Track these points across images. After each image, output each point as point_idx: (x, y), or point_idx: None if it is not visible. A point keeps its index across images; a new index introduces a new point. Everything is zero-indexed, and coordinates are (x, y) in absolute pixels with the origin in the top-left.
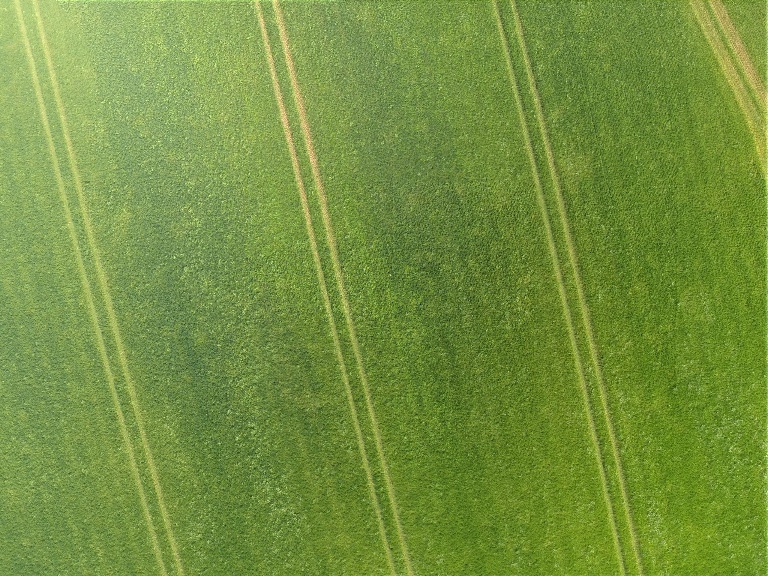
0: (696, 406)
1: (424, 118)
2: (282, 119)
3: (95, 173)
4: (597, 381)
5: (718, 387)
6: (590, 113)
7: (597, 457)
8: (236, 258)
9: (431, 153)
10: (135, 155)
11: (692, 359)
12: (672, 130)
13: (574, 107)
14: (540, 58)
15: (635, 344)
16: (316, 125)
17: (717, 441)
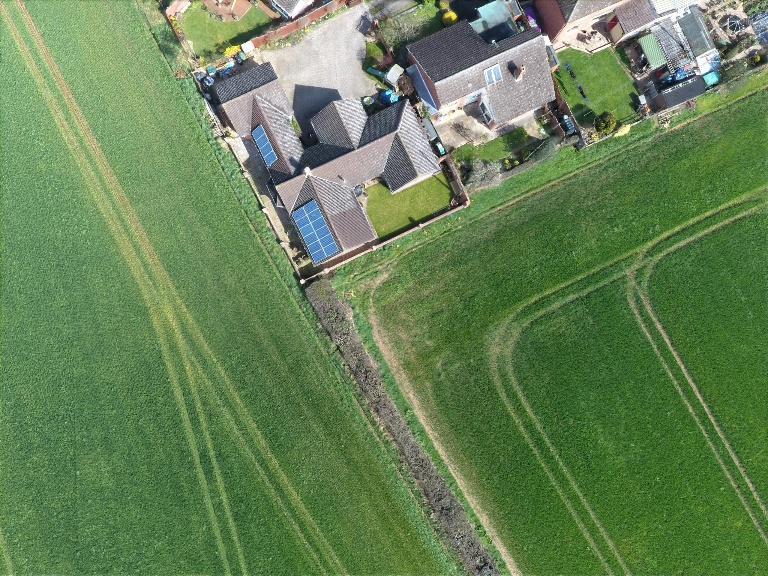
0: (101, 569)
1: None
2: None
3: None
4: (0, 550)
5: (121, 550)
6: None
7: None
8: None
9: None
10: None
11: (94, 525)
12: (67, 306)
13: None
14: None
15: (36, 513)
16: None
17: None
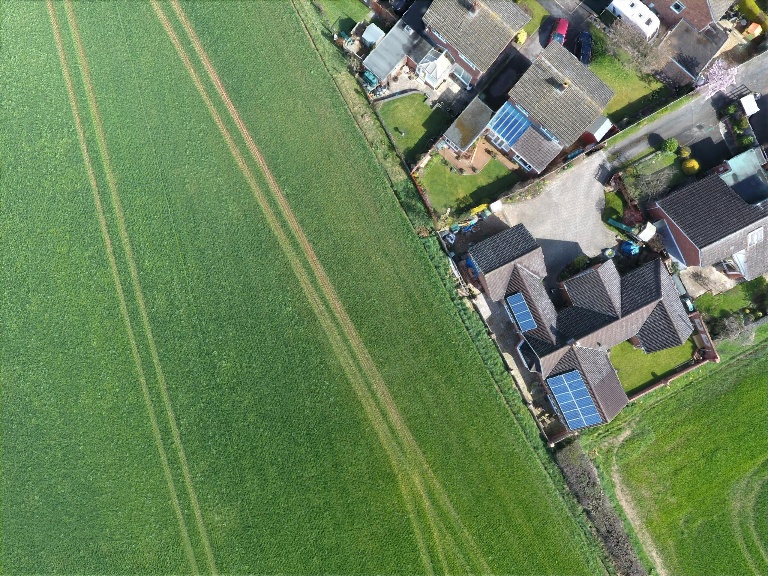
0: None
1: (65, 478)
2: None
3: None
4: None
5: None
6: (235, 464)
7: None
8: None
9: (74, 513)
10: None
11: None
12: (318, 475)
13: (219, 459)
14: (183, 412)
15: None
16: None
17: None
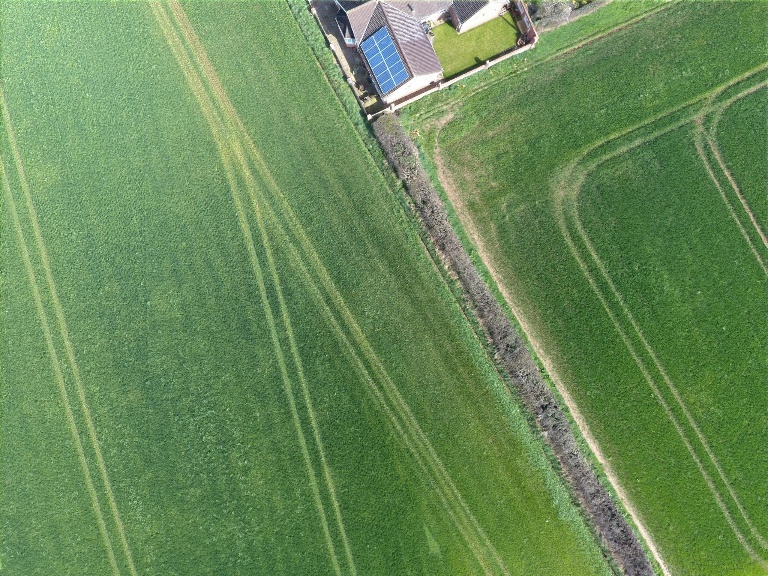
0: (170, 399)
1: None
2: None
3: None
4: (73, 377)
5: (190, 380)
6: (56, 123)
7: (78, 449)
8: None
9: None
10: None
11: (163, 355)
12: (138, 139)
13: (41, 117)
14: (6, 71)
15: (108, 341)
16: None
17: (192, 431)
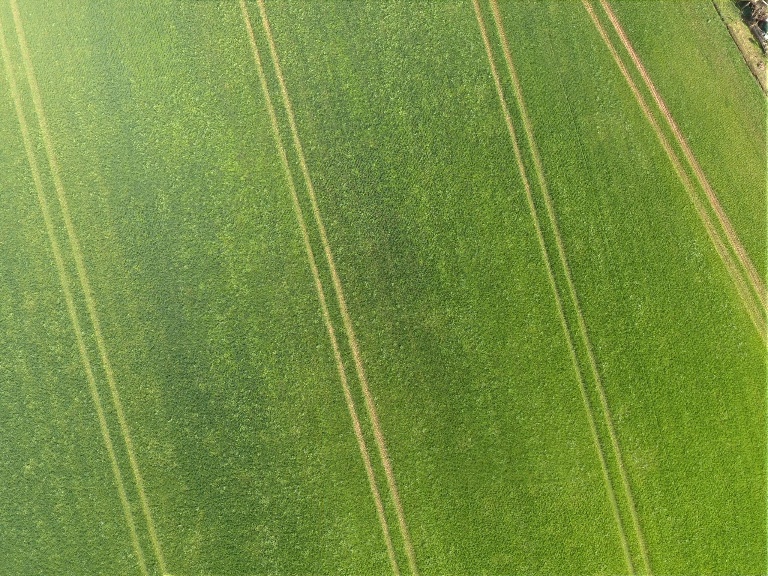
0: None
1: (495, 420)
2: (355, 428)
3: (164, 495)
4: None
5: None
6: (653, 408)
7: None
8: (314, 574)
9: (504, 455)
10: (206, 474)
11: None
12: (729, 419)
13: (638, 402)
14: (604, 355)
15: None
16: (389, 433)
17: None
